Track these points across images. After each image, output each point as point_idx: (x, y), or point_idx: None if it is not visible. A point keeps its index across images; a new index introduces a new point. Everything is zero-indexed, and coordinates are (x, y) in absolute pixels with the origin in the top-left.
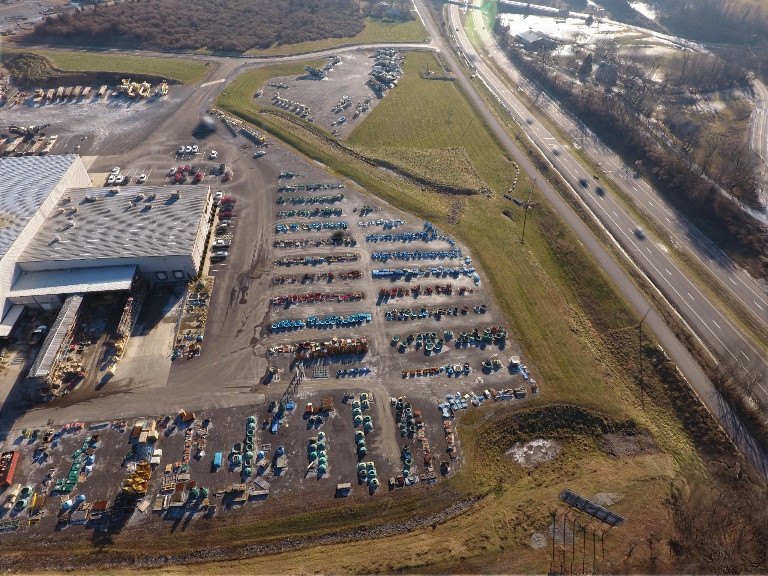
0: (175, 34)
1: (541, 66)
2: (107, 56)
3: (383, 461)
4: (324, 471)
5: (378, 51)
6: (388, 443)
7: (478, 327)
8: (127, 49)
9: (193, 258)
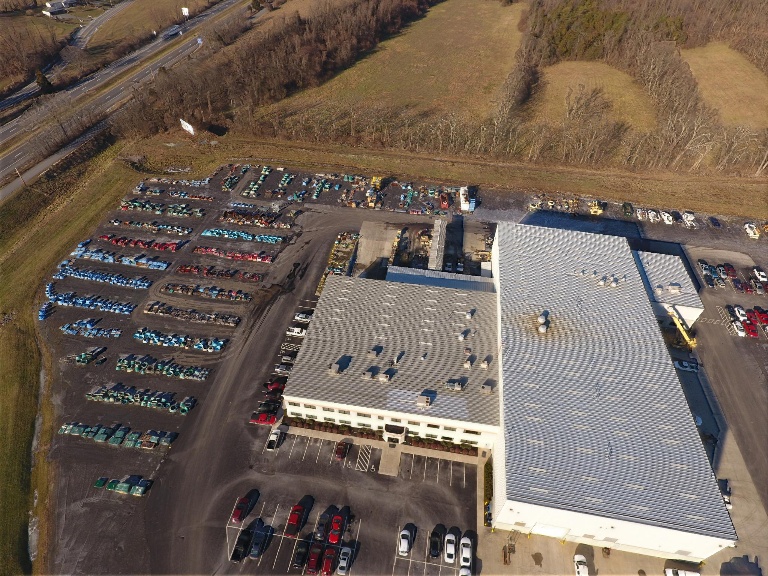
0: None
1: None
2: None
3: None
4: None
5: None
6: (249, 177)
7: (134, 212)
8: None
9: None
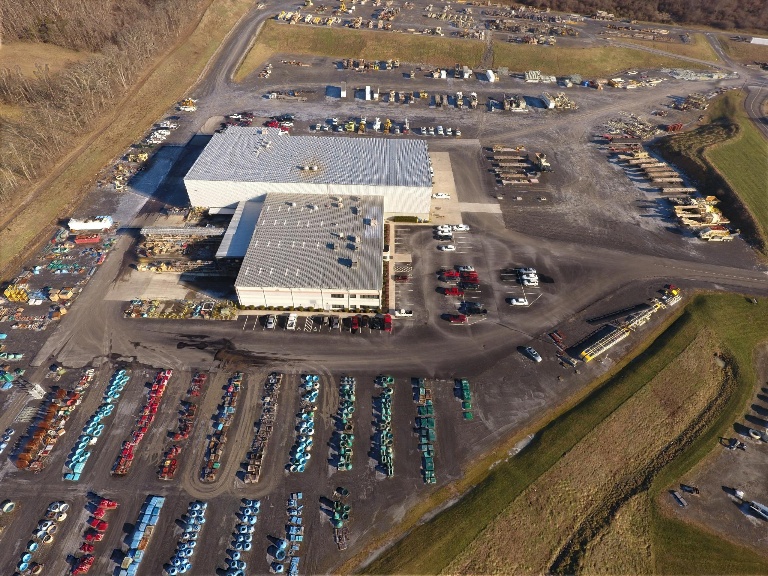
0: None
1: None
2: None
3: None
4: None
5: None
6: None
7: None
8: None
9: (240, 291)
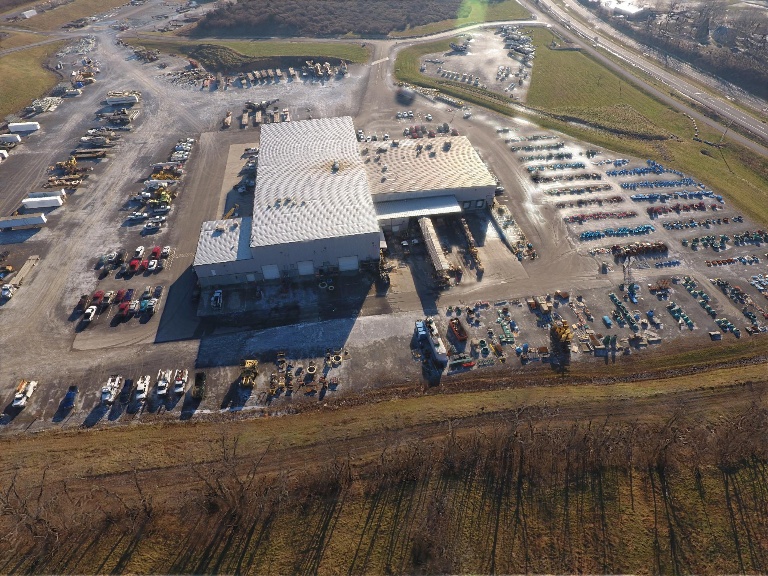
0: (321, 22)
1: (654, 33)
2: (276, 43)
3: (732, 318)
4: (693, 325)
5: (501, 28)
6: (728, 307)
7: (744, 231)
8: (286, 37)
9: None
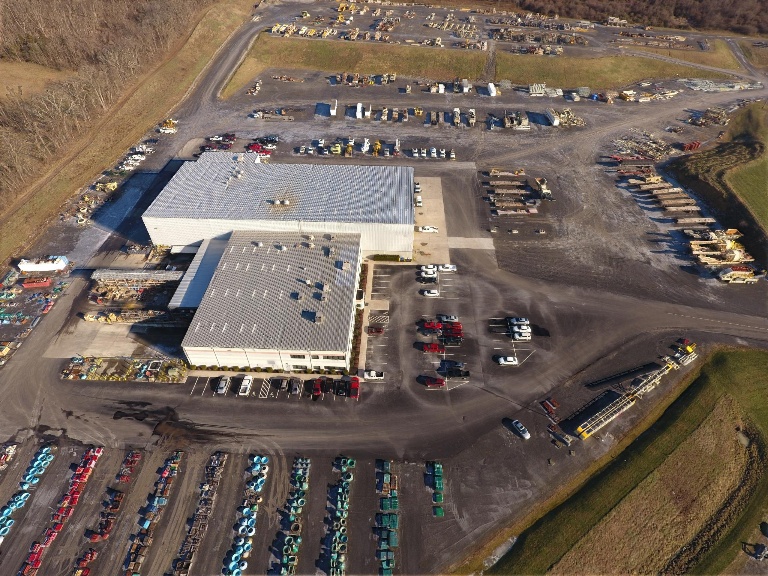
0: None
1: None
2: None
3: None
4: None
5: None
6: None
7: None
8: None
9: (188, 351)
